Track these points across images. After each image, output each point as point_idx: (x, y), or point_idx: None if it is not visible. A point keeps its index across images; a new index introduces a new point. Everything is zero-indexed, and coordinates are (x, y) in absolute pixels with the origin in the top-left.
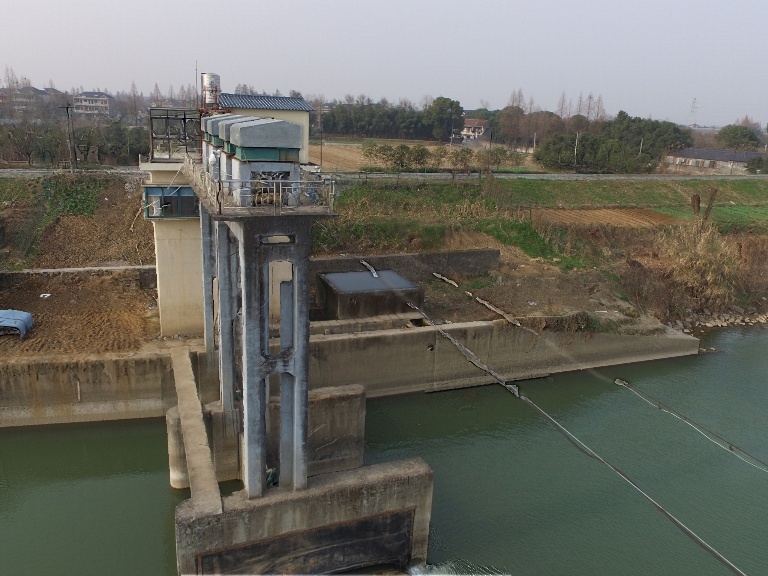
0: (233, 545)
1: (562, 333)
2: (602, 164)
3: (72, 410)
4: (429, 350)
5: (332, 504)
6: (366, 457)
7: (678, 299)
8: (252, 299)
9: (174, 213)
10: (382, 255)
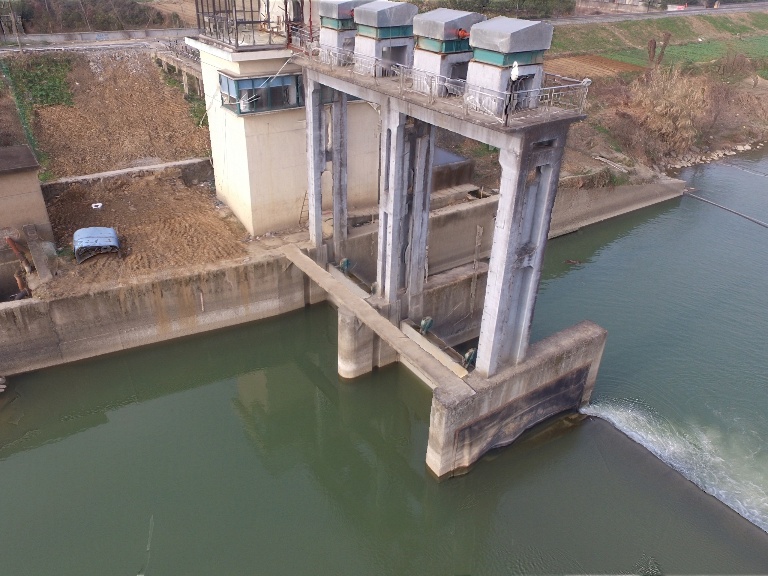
0: (479, 417)
1: (593, 190)
2: (541, 8)
3: (196, 321)
4: None
5: (544, 370)
6: None
7: (652, 145)
8: (518, 204)
9: (264, 106)
10: None
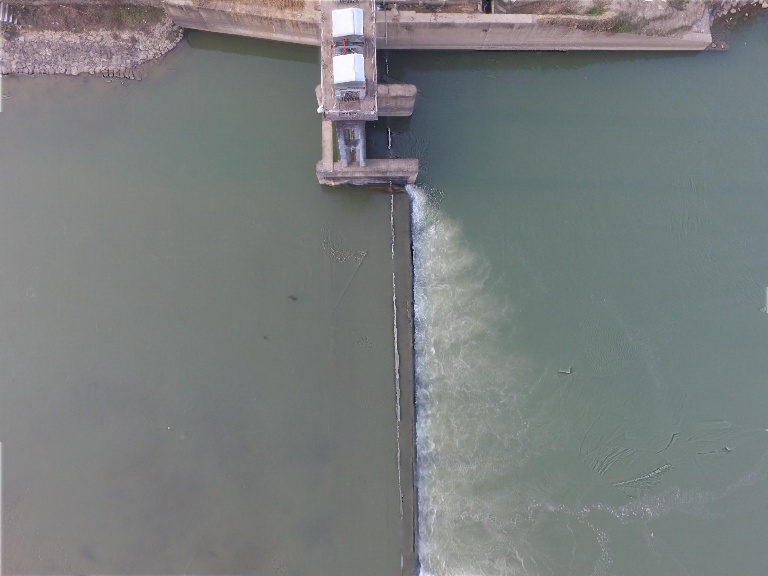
0: (337, 176)
1: (588, 32)
2: None
3: (272, 35)
4: (483, 32)
5: None
6: (417, 104)
7: None
8: (340, 135)
9: None
10: None
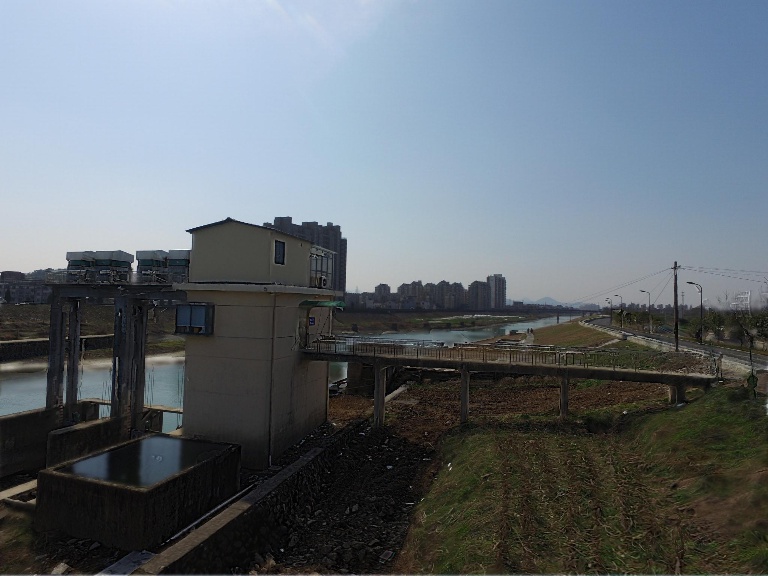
0: None
1: None
2: None
3: None
4: None
5: None
6: None
7: None
8: None
9: None
10: (226, 517)
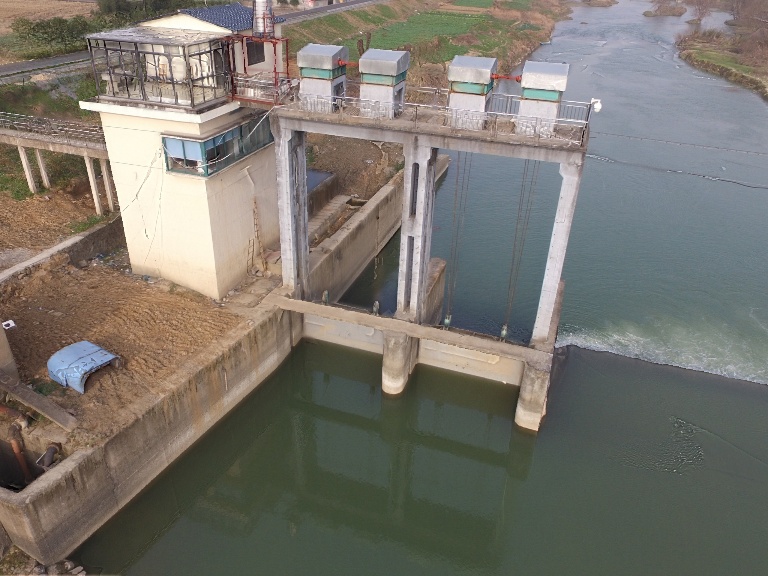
0: None
1: None
2: None
3: (222, 404)
4: (377, 221)
5: None
6: None
7: None
8: None
9: (222, 163)
10: None
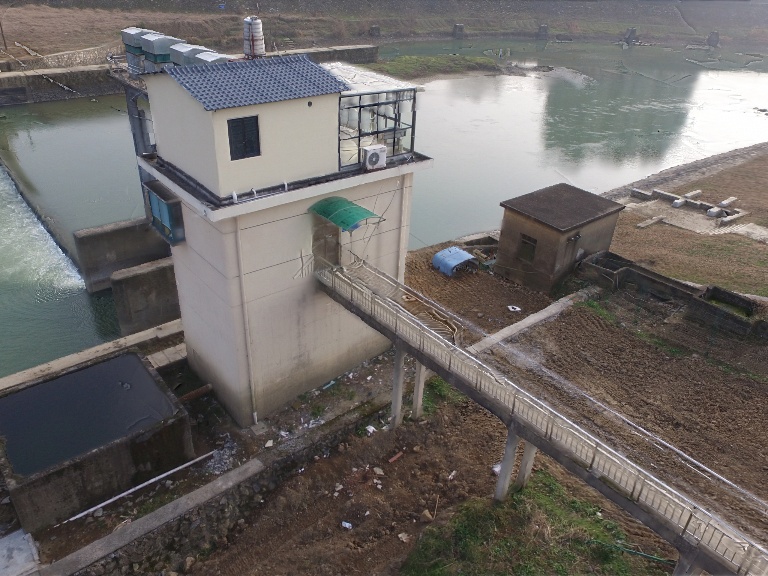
0: None
1: None
2: None
3: None
4: None
5: None
6: None
7: None
8: None
9: None
10: None
